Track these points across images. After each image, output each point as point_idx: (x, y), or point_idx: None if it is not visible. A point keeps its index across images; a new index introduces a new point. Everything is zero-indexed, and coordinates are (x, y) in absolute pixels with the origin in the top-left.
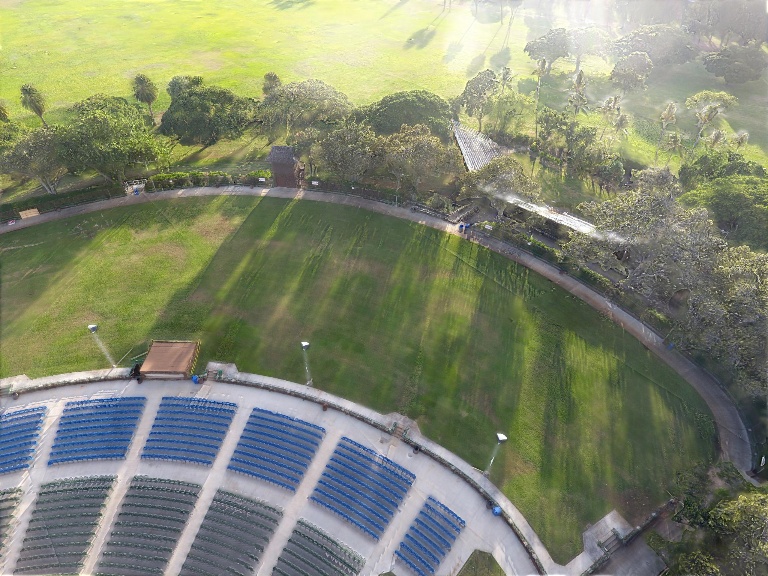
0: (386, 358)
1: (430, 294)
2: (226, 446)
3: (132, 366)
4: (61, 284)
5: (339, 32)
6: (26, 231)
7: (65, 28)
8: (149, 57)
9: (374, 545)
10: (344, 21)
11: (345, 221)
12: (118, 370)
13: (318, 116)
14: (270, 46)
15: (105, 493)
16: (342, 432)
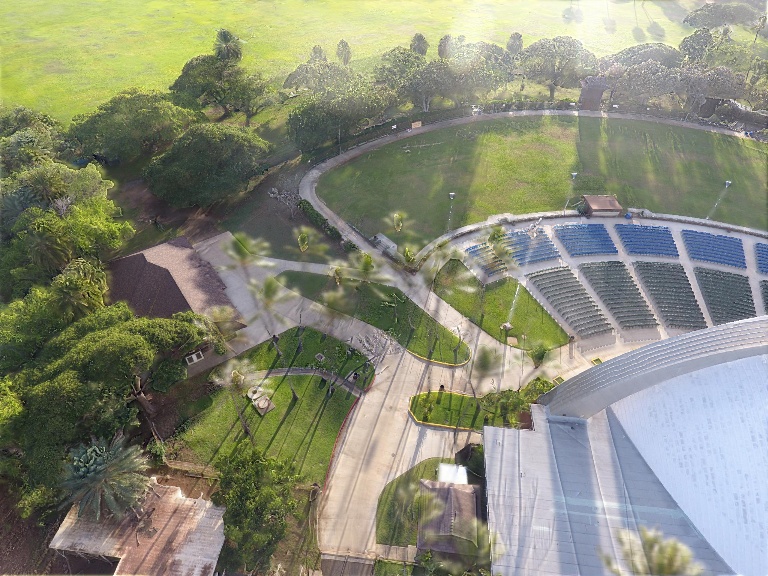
0: (752, 205)
1: (755, 171)
2: (678, 249)
3: (576, 209)
4: (482, 166)
5: (498, 10)
6: (424, 135)
7: (259, 8)
8: (357, 29)
9: None
10: (493, 2)
11: (655, 130)
12: (569, 211)
13: (578, 63)
14: (450, 21)
15: (624, 268)
16: (751, 242)
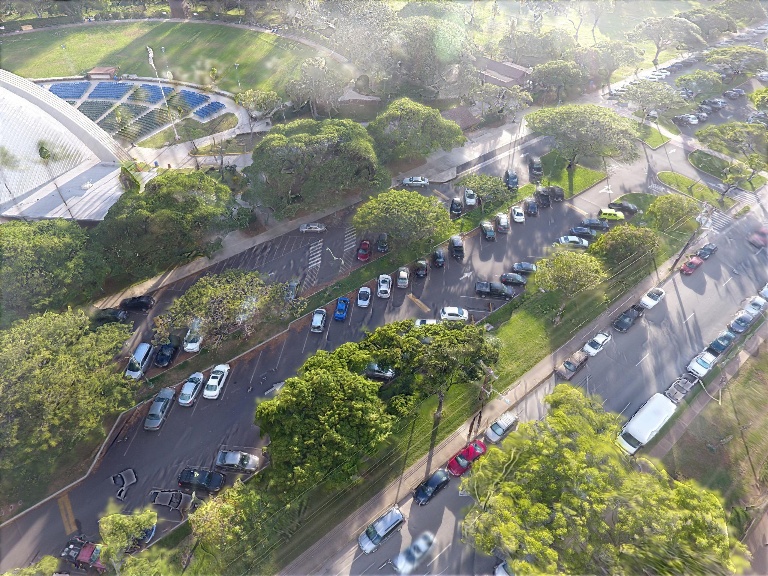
0: None
1: (243, 52)
2: (128, 95)
3: (85, 75)
4: (47, 52)
5: None
6: (26, 34)
7: None
8: None
9: (186, 113)
10: None
11: (209, 30)
12: (78, 76)
13: None
14: None
15: None
16: None
